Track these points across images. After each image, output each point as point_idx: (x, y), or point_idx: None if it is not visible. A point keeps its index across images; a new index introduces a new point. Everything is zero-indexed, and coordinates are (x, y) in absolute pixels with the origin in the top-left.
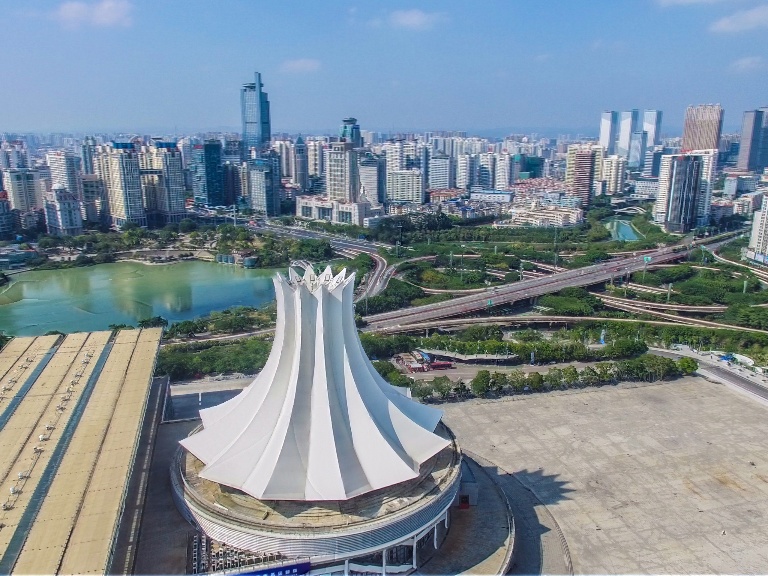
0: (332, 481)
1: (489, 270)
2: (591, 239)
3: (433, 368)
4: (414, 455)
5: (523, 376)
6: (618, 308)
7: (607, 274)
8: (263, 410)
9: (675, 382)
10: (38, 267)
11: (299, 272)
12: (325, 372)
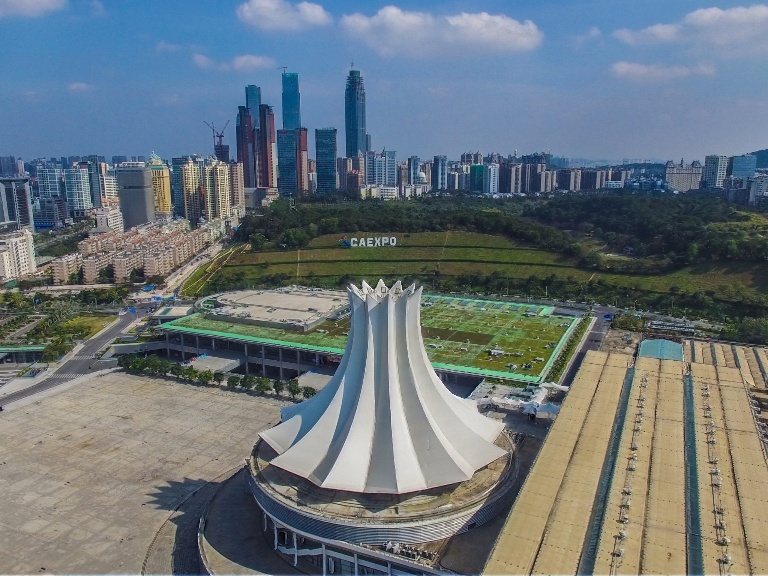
0: None
1: None
2: None
3: None
4: None
5: None
6: None
7: None
8: None
9: None
10: None
11: None
12: None
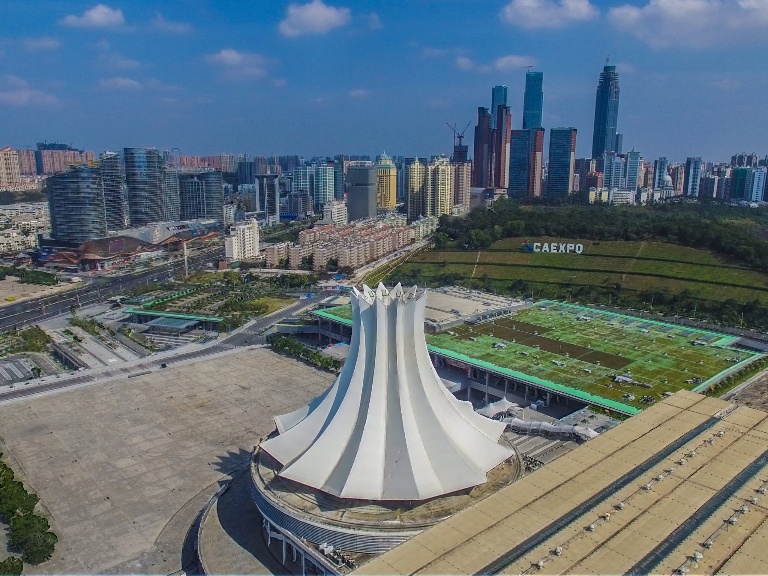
0: None
1: None
2: None
3: None
4: None
5: None
6: None
7: None
8: None
9: None
10: None
11: None
12: None
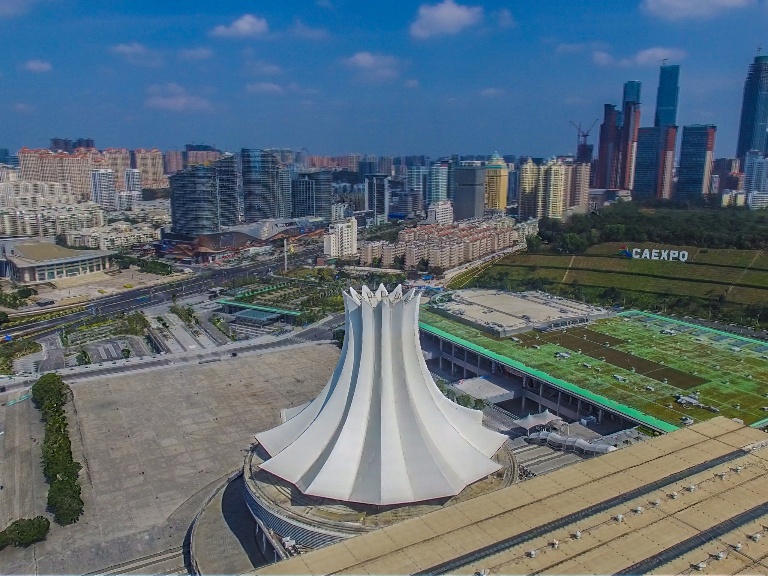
0: (472, 413)
1: None
2: None
3: None
4: None
5: None
6: None
7: None
8: None
9: None
10: None
11: None
12: None
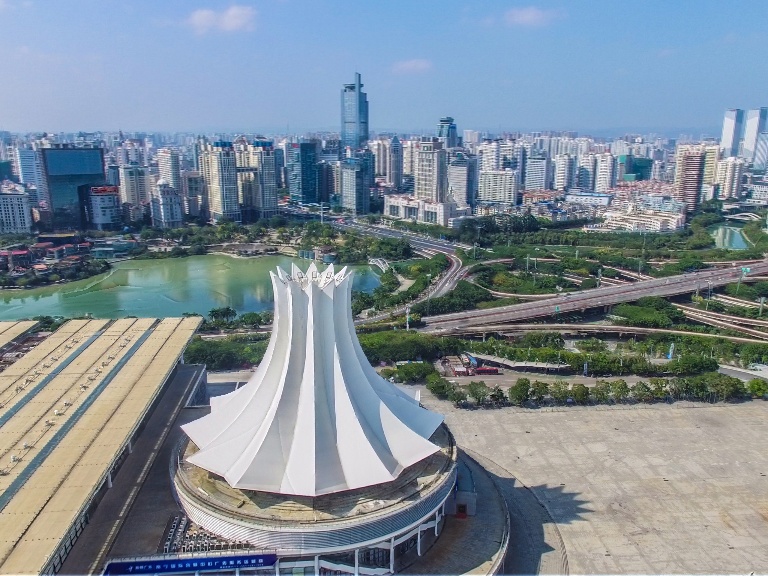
0: (306, 476)
1: (568, 275)
2: (691, 246)
3: (478, 373)
4: (400, 458)
5: (566, 387)
6: (701, 321)
7: (696, 284)
8: (254, 402)
9: (741, 405)
10: (138, 256)
11: (376, 270)
12: (313, 368)
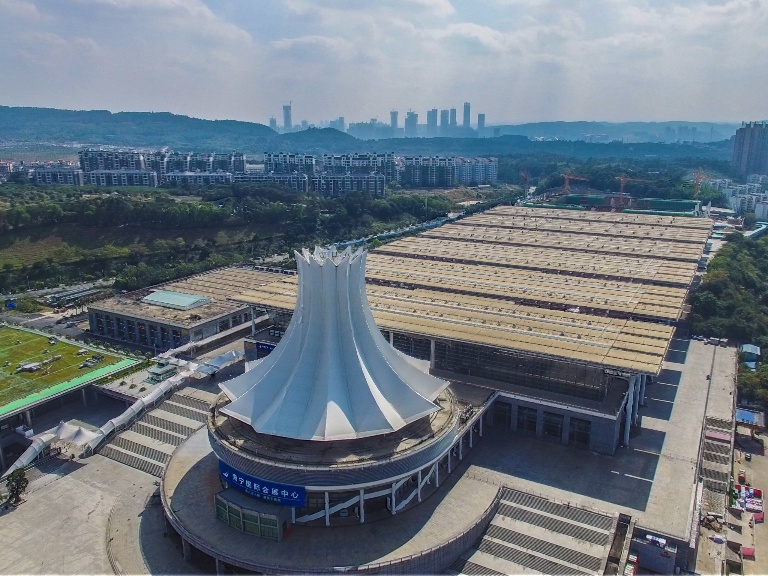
0: None
1: None
2: None
3: None
4: None
5: None
6: None
7: None
8: None
9: None
10: None
11: None
12: None
